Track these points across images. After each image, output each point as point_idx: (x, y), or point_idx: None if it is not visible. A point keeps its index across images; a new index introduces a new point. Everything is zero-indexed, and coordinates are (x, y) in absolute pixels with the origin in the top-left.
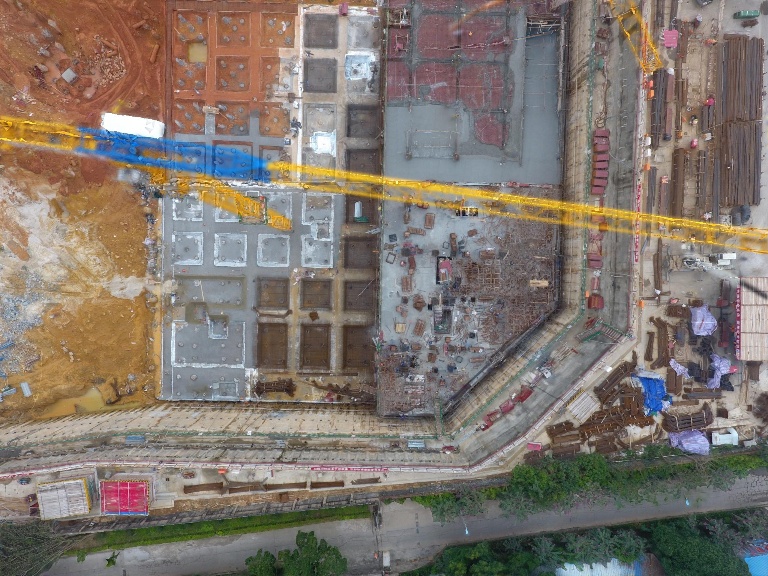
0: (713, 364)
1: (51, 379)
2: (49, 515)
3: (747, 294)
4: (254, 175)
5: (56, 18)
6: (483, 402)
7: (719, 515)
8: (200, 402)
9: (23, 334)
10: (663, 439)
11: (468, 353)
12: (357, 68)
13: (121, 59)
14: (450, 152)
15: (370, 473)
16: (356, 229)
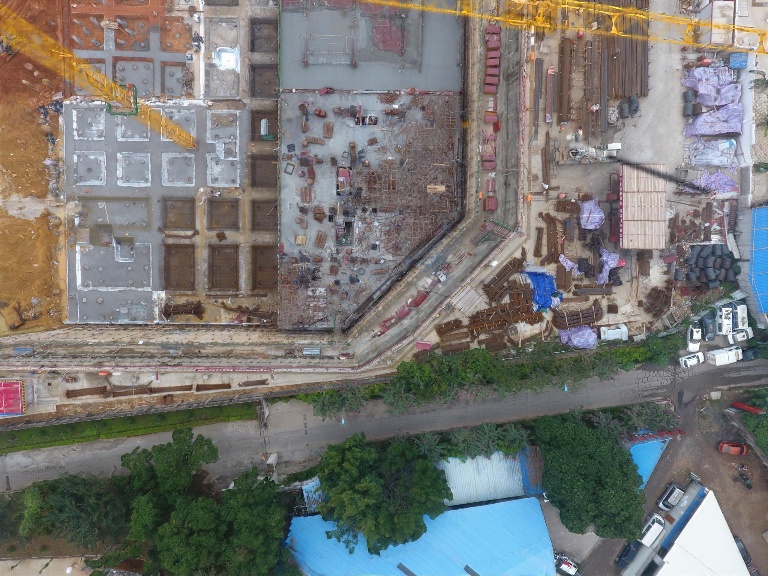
0: (602, 259)
1: None
2: None
3: (629, 181)
4: (156, 92)
5: None
6: (379, 308)
7: (609, 411)
8: (106, 325)
9: None
10: (554, 337)
11: (371, 265)
12: None
13: None
14: (347, 58)
15: (257, 375)
16: (262, 147)
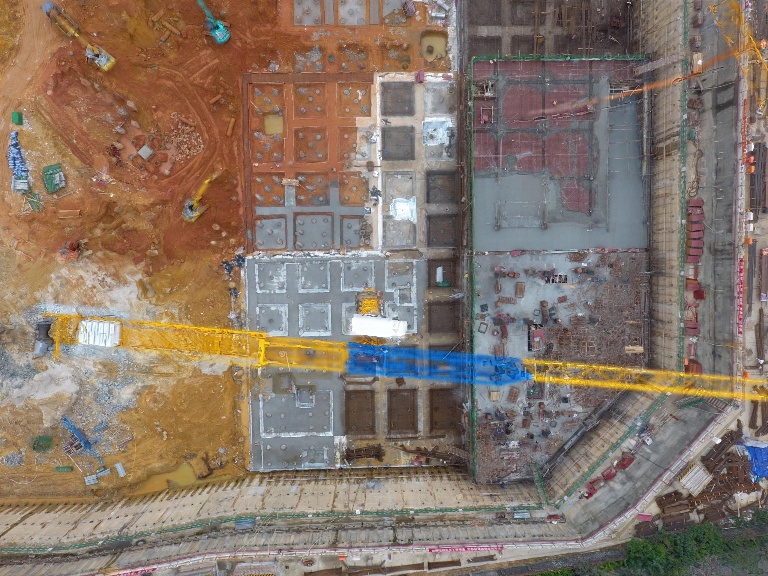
0: None
1: (145, 458)
2: None
3: None
4: (336, 245)
5: (133, 98)
6: (585, 470)
7: None
8: (292, 472)
9: (116, 416)
10: None
11: (561, 417)
12: (433, 133)
13: (199, 135)
14: (539, 221)
15: (485, 551)
16: (439, 294)
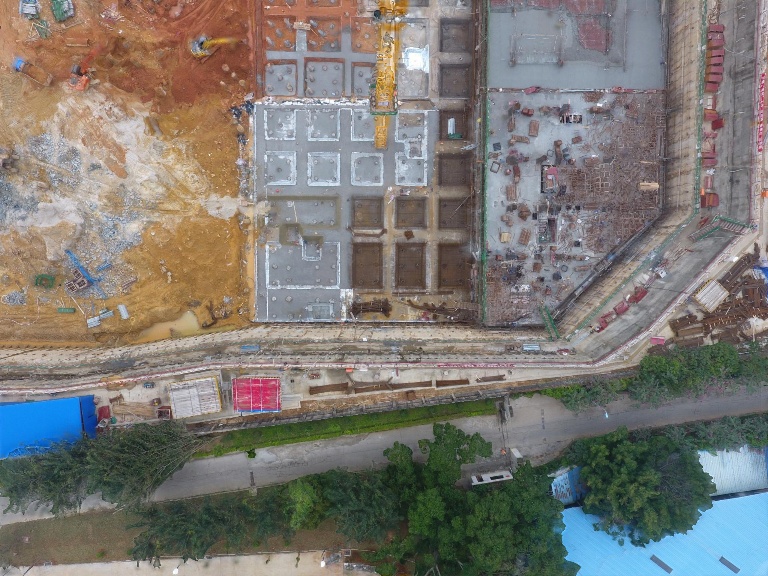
0: None
1: (148, 301)
2: (181, 414)
3: None
4: (347, 92)
5: None
6: (597, 304)
7: None
8: (297, 323)
9: (120, 255)
10: None
11: (573, 262)
12: None
13: None
14: (554, 57)
15: (494, 371)
16: (450, 146)
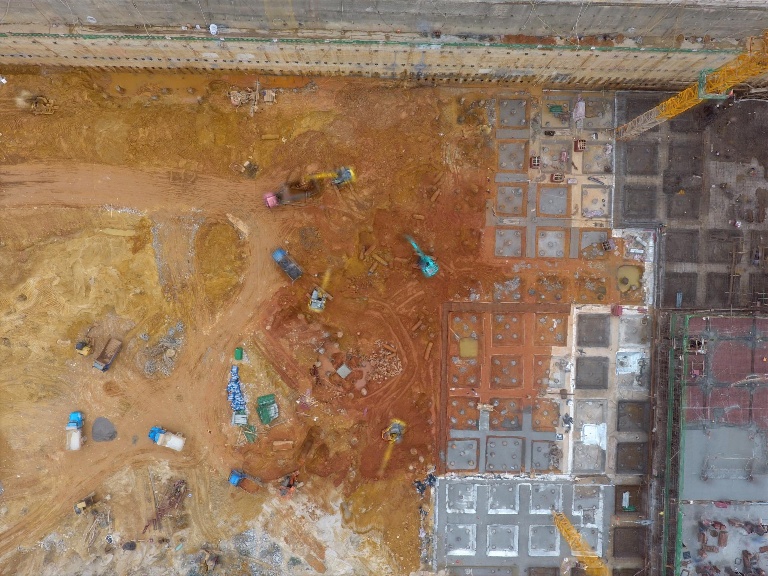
0: None
1: None
2: None
3: None
4: (526, 469)
5: (342, 327)
6: None
7: None
8: None
9: None
10: None
11: None
12: (623, 360)
13: (399, 360)
14: (745, 474)
15: None
16: (625, 520)
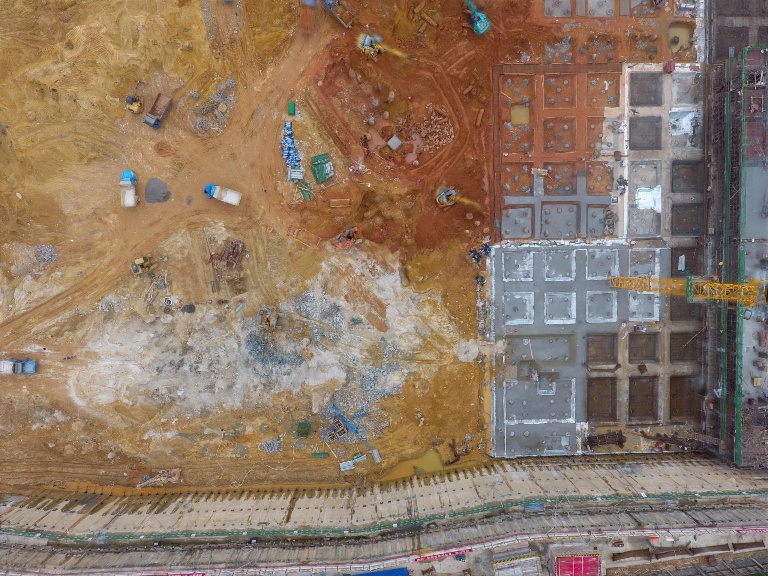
0: None
1: (400, 444)
2: None
3: None
4: (582, 234)
5: (393, 89)
6: None
7: None
8: (537, 458)
9: (376, 402)
10: None
11: None
12: (675, 123)
13: (451, 125)
14: None
15: None
16: (682, 282)
